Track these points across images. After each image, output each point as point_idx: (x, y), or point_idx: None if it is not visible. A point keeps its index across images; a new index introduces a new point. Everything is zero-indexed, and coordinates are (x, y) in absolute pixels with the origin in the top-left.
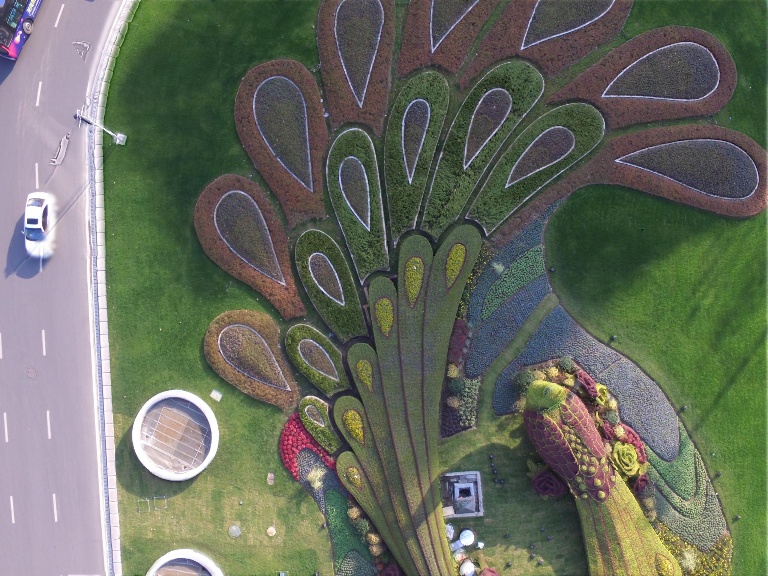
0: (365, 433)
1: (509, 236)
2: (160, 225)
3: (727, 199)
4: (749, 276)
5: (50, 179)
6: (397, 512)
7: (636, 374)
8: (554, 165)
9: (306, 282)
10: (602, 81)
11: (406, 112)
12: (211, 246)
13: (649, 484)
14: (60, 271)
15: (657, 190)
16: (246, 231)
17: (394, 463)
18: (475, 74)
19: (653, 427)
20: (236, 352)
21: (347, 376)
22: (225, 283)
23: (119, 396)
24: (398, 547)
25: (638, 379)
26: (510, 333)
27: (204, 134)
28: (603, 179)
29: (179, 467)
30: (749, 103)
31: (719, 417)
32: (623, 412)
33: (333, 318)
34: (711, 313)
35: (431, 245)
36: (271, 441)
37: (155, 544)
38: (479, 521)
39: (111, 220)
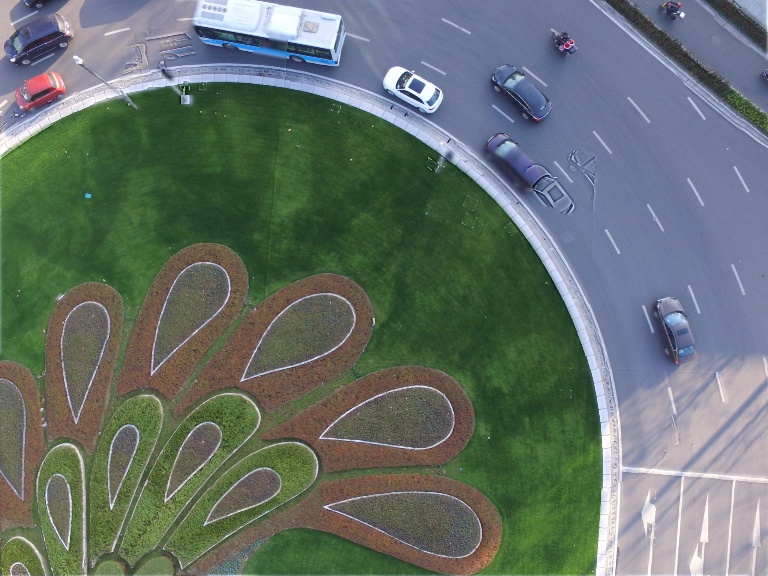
0: None
1: (204, 572)
2: None
3: (442, 556)
4: None
5: None
6: None
7: None
8: (256, 508)
9: None
10: (321, 423)
11: (115, 436)
12: None
13: None
14: None
15: (364, 542)
16: None
17: None
18: (190, 403)
19: None
20: None
21: None
22: None
23: None
24: None
25: None
26: None
27: None
28: (308, 525)
29: None
30: (485, 455)
31: None
32: None
33: None
34: None
35: (129, 569)
36: None
37: None
38: None
39: None
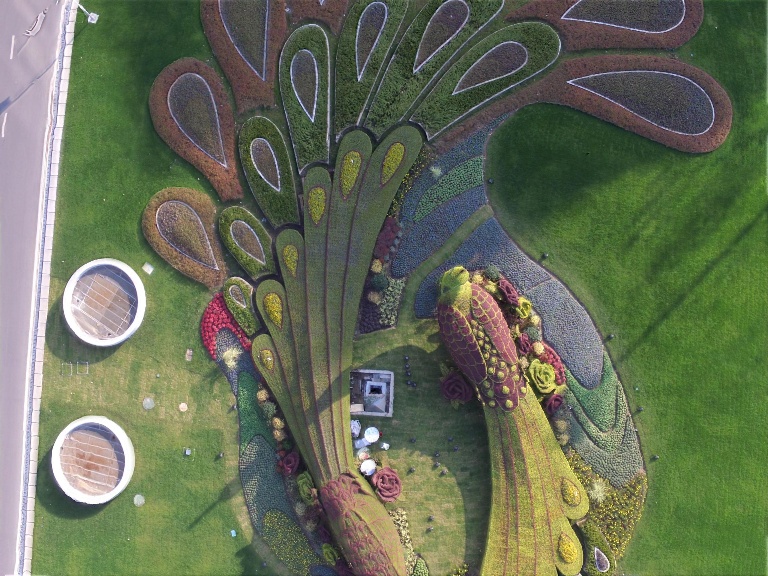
0: (283, 317)
1: (451, 143)
2: (117, 100)
3: (679, 134)
4: (694, 213)
5: (22, 48)
6: (303, 396)
7: (564, 296)
8: (504, 78)
9: (246, 165)
10: (563, 3)
11: (363, 12)
12: (161, 123)
13: (565, 408)
14: (20, 136)
15: (606, 115)
16: (196, 111)
17: (306, 347)
18: None
19: (576, 351)
20: (171, 226)
21: (274, 261)
22: (170, 160)
23: (58, 260)
24: (301, 432)
25: (566, 301)
26: (440, 238)
27: (170, 18)
28: (552, 98)
29: (104, 334)
30: (713, 42)
31: (646, 351)
32: (546, 332)
33: (267, 202)
34: (649, 245)
35: (372, 143)
36: (194, 318)
37: (73, 408)
38: (387, 422)
39: (73, 92)
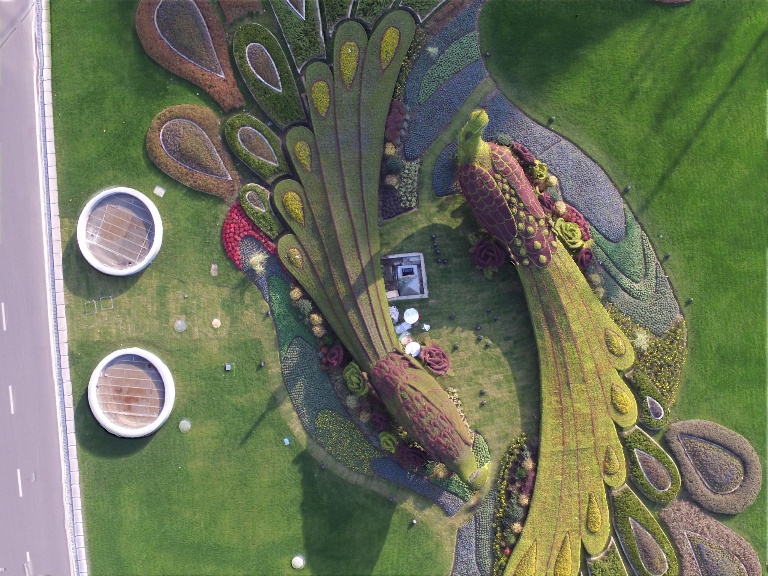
0: (305, 213)
1: (443, 22)
2: (103, 31)
3: None
4: (687, 61)
5: None
6: (338, 285)
7: (577, 155)
8: None
9: (244, 71)
10: None
11: None
12: (152, 45)
13: (596, 263)
14: (8, 83)
15: None
16: (185, 28)
17: (333, 236)
18: None
19: (597, 207)
20: (177, 144)
21: (287, 162)
22: (166, 81)
23: (65, 200)
24: (340, 322)
25: (579, 160)
26: (448, 116)
27: None
28: None
29: (124, 264)
30: None
31: (664, 198)
32: (565, 192)
33: (271, 104)
34: (650, 96)
35: None
36: (214, 232)
37: (102, 346)
38: (424, 303)
39: (57, 32)
